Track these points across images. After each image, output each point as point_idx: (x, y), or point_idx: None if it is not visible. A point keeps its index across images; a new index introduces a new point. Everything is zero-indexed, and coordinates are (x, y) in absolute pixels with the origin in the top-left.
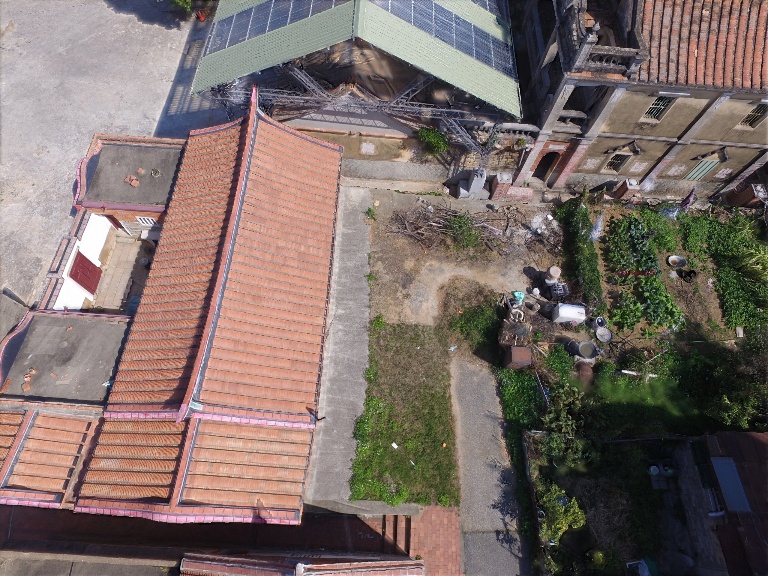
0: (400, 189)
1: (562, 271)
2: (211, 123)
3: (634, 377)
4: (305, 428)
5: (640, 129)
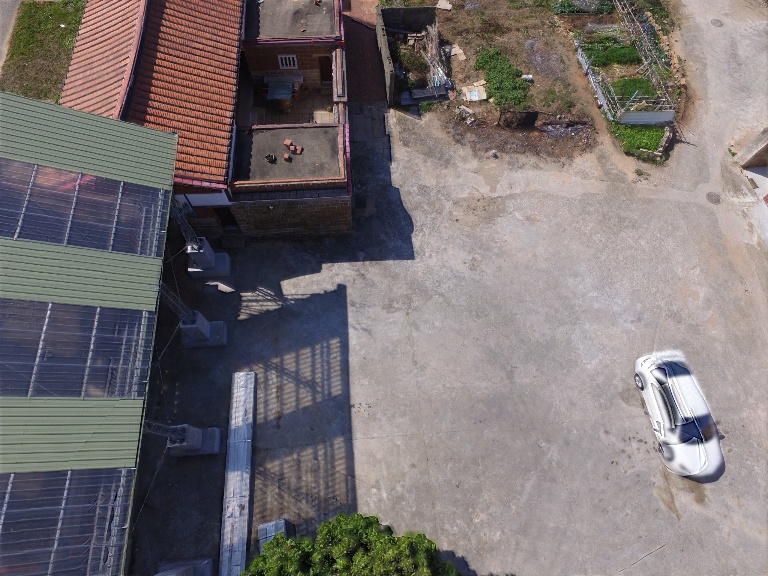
0: None
1: None
2: (274, 332)
3: None
4: None
5: None
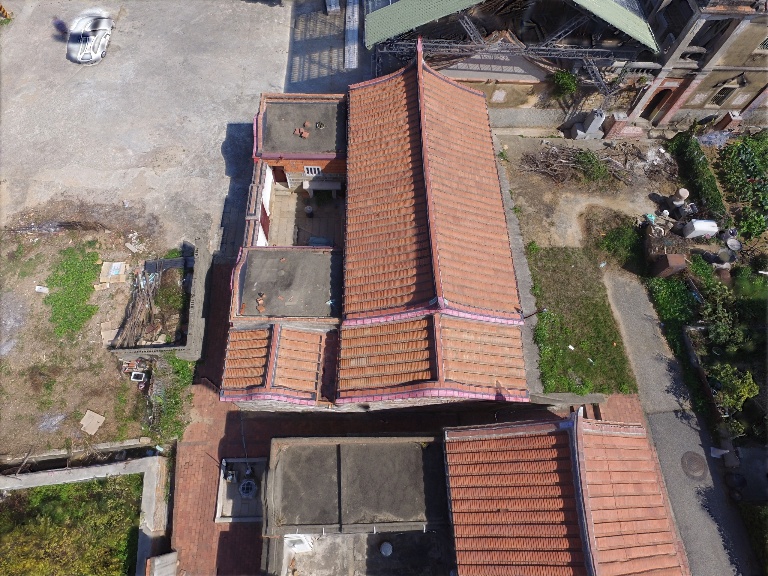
0: None
1: None
2: (333, 88)
3: None
4: (516, 325)
5: (751, 60)
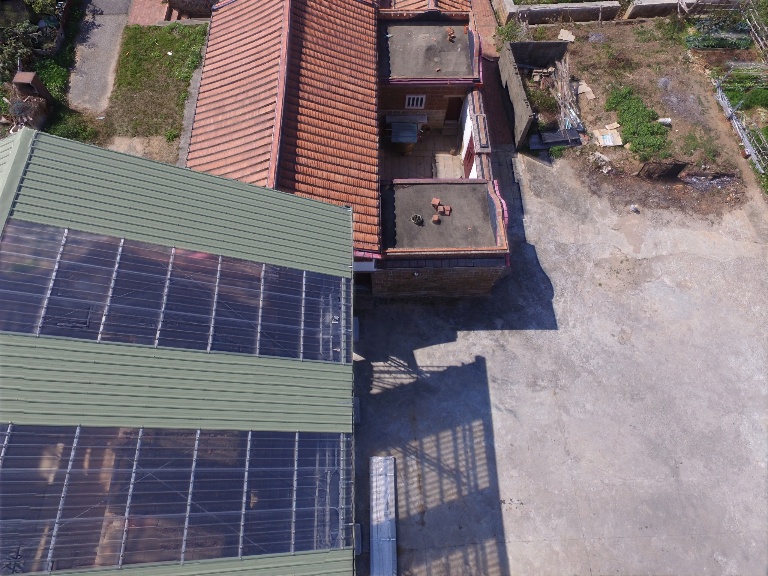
0: None
1: None
2: (411, 409)
3: None
4: None
5: None
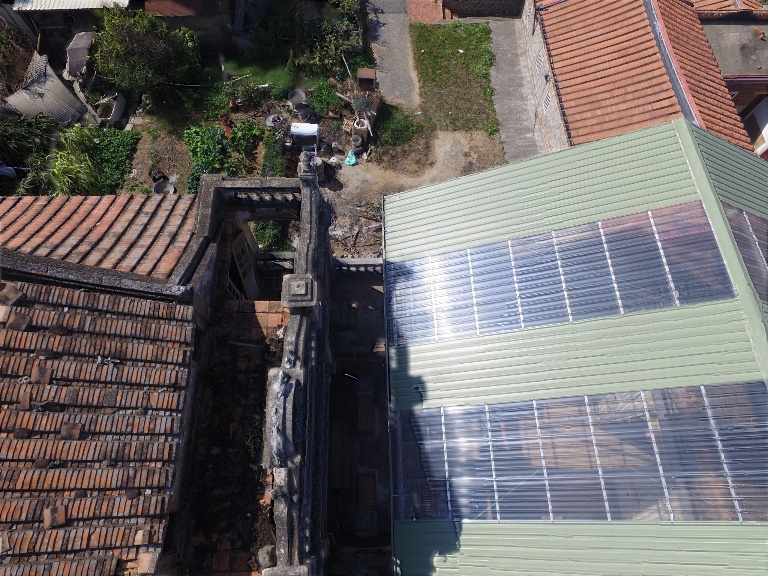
0: None
1: None
2: None
3: None
4: None
5: None
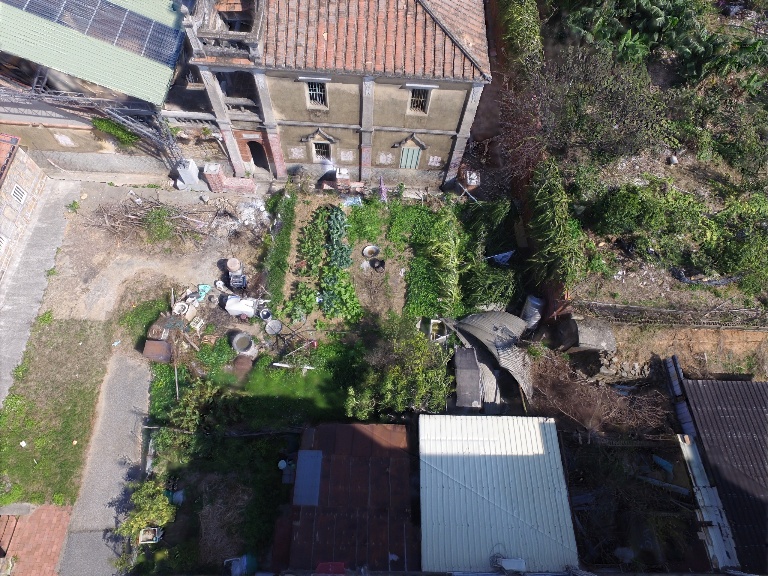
0: (122, 182)
1: (258, 263)
2: None
3: (288, 370)
4: None
5: (316, 116)
